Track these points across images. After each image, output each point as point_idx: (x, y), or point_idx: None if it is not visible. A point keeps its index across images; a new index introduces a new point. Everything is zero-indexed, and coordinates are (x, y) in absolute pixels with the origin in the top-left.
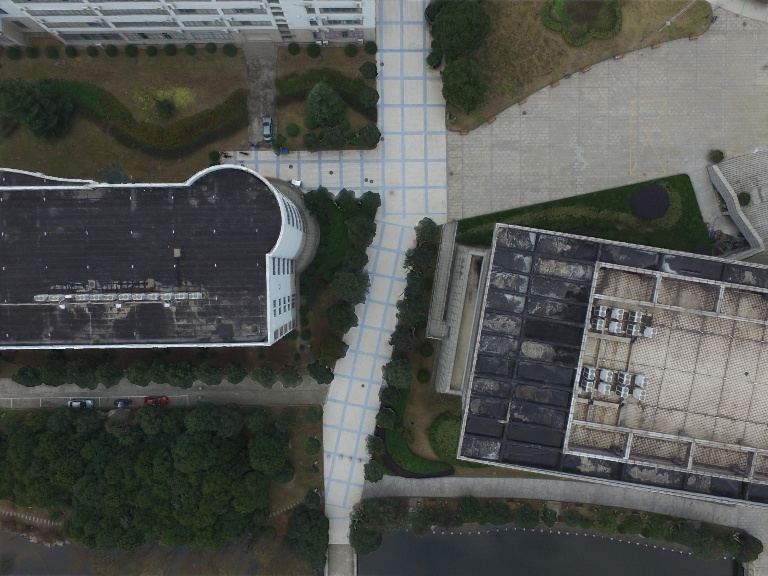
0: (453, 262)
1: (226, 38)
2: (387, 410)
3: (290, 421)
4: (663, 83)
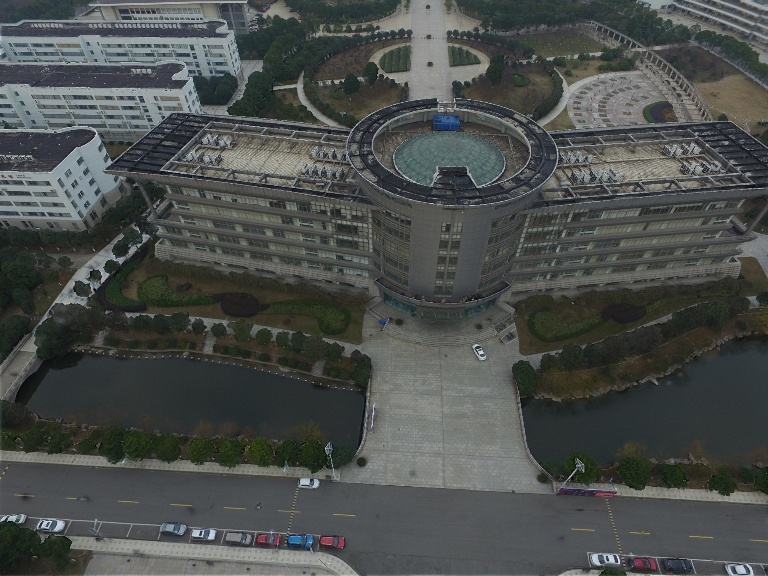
0: None
1: (129, 139)
2: None
3: (48, 262)
4: None
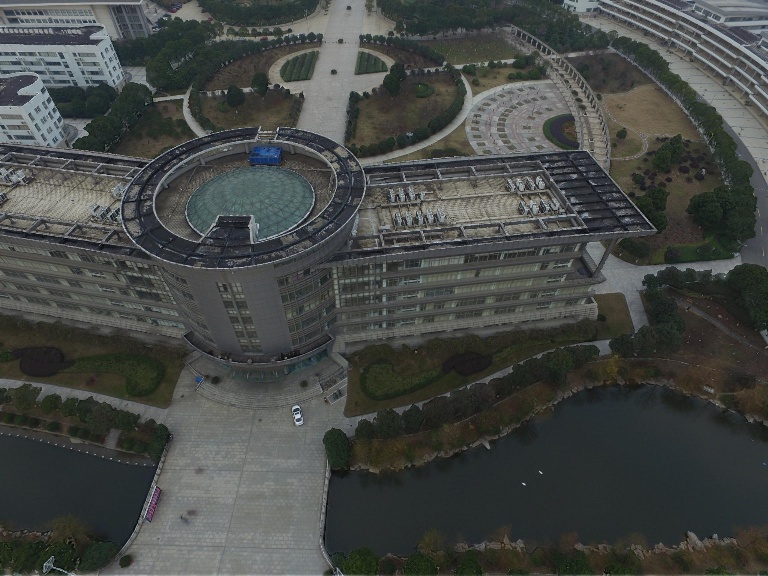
0: None
1: None
2: None
3: None
4: None
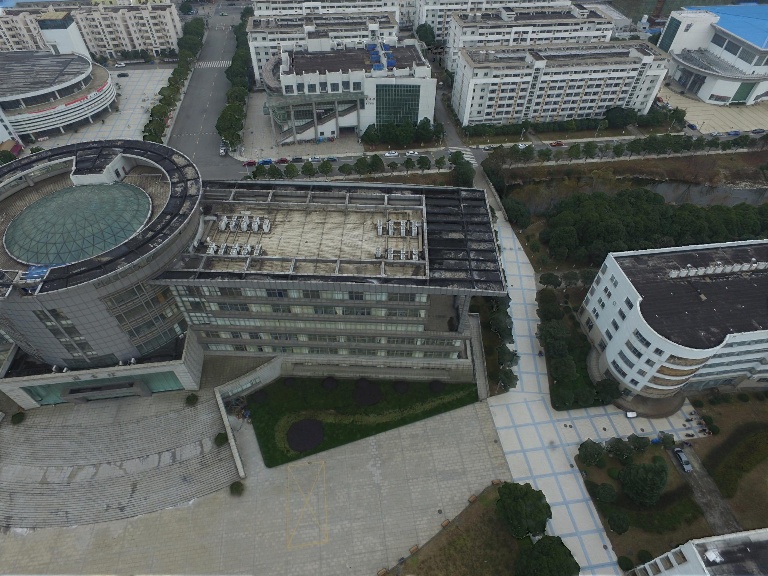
0: (473, 369)
1: None
2: None
3: None
4: (292, 569)
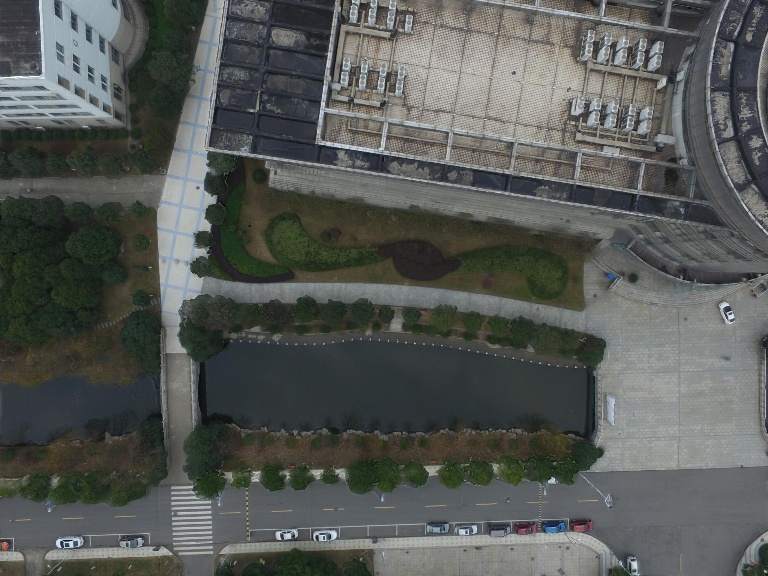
0: None
1: None
2: (216, 204)
3: None
4: None
